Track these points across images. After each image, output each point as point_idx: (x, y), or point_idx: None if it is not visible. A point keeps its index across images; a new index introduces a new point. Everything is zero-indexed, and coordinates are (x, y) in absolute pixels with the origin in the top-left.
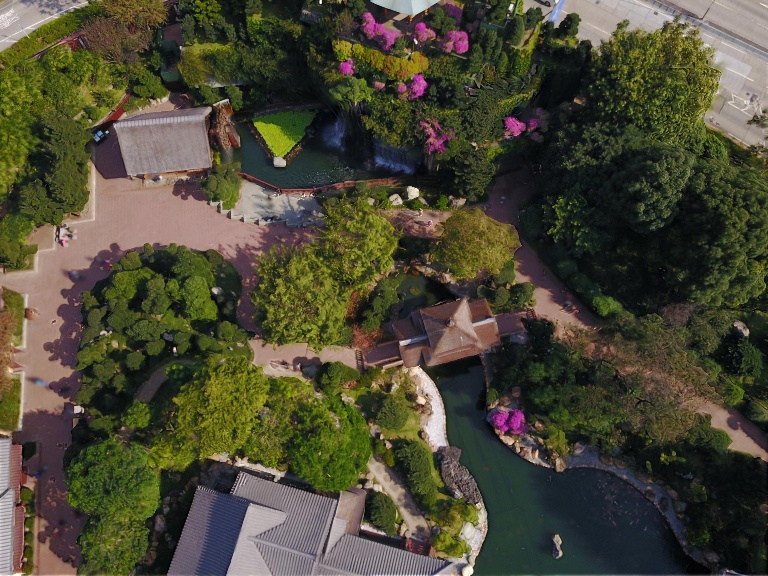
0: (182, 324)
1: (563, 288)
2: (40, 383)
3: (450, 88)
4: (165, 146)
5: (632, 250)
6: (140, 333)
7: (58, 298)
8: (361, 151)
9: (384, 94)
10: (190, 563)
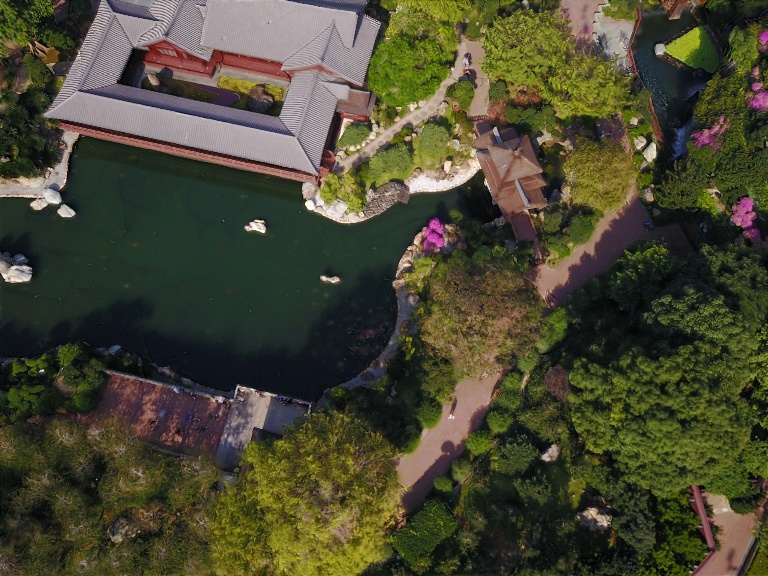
0: None
1: None
2: None
3: (767, 121)
4: None
5: None
6: None
7: None
8: (686, 106)
9: (747, 78)
10: None
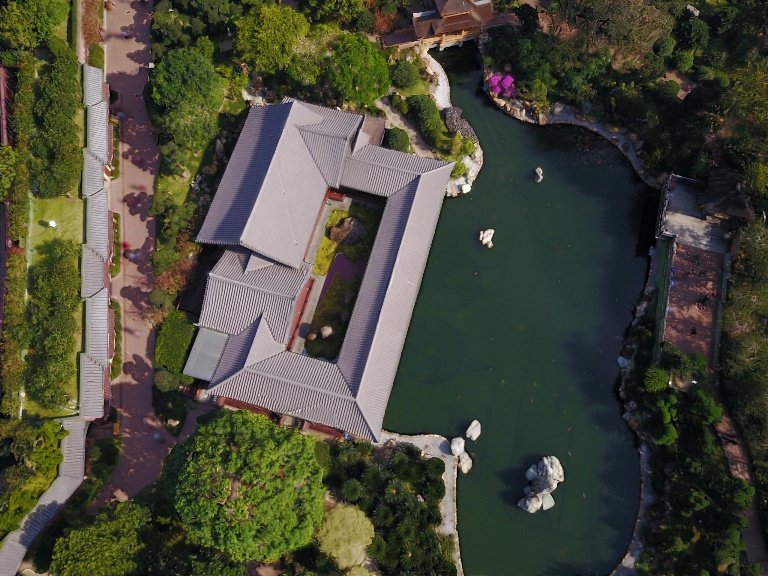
0: None
1: None
2: (119, 53)
3: None
4: None
5: None
6: (203, 3)
7: None
8: None
9: None
10: (247, 151)
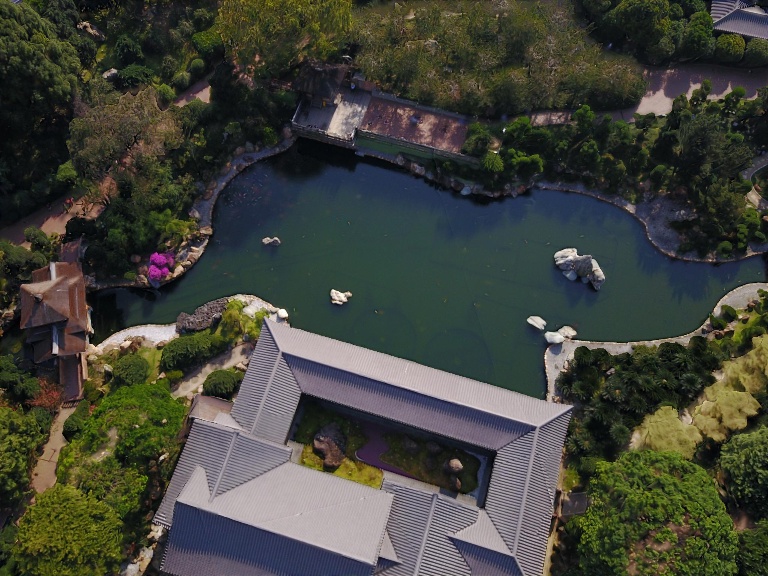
0: None
1: (47, 208)
2: None
3: None
4: None
5: (18, 141)
6: None
7: None
8: None
9: None
10: (232, 570)
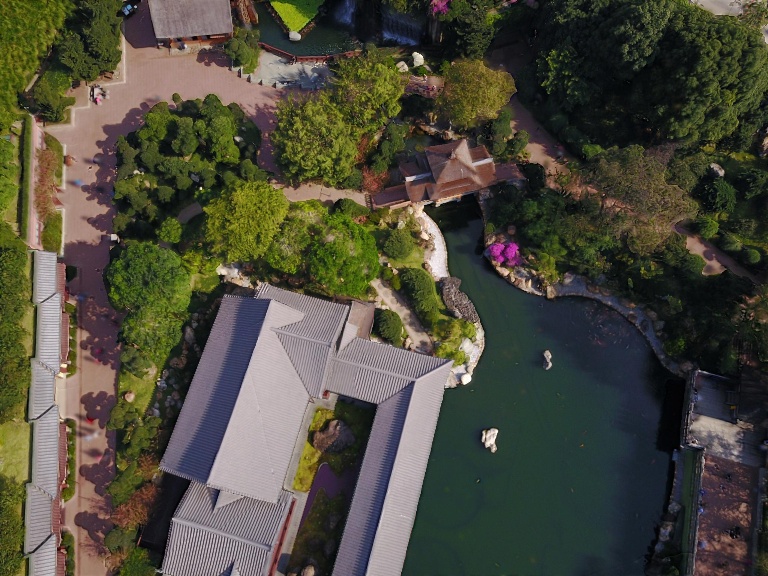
0: (207, 167)
1: (556, 144)
2: (79, 219)
3: None
4: (191, 10)
5: (619, 104)
6: (171, 168)
7: (94, 148)
8: (370, 23)
9: None
10: (219, 354)
